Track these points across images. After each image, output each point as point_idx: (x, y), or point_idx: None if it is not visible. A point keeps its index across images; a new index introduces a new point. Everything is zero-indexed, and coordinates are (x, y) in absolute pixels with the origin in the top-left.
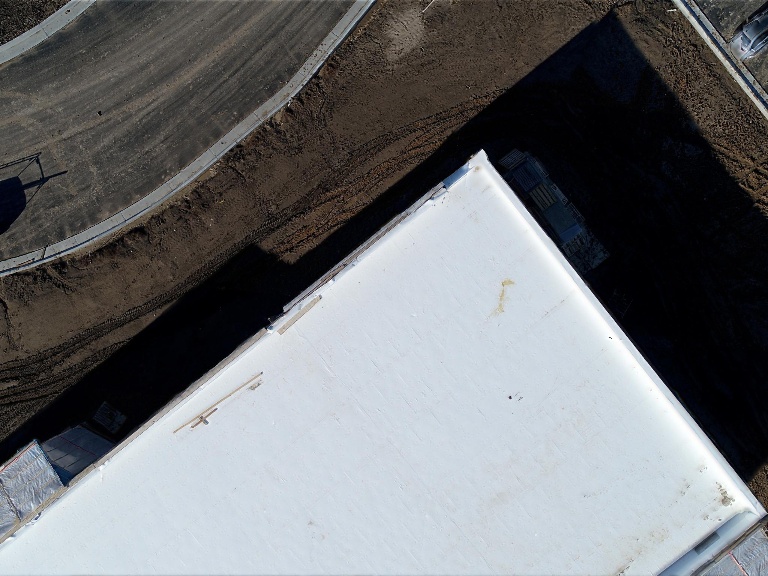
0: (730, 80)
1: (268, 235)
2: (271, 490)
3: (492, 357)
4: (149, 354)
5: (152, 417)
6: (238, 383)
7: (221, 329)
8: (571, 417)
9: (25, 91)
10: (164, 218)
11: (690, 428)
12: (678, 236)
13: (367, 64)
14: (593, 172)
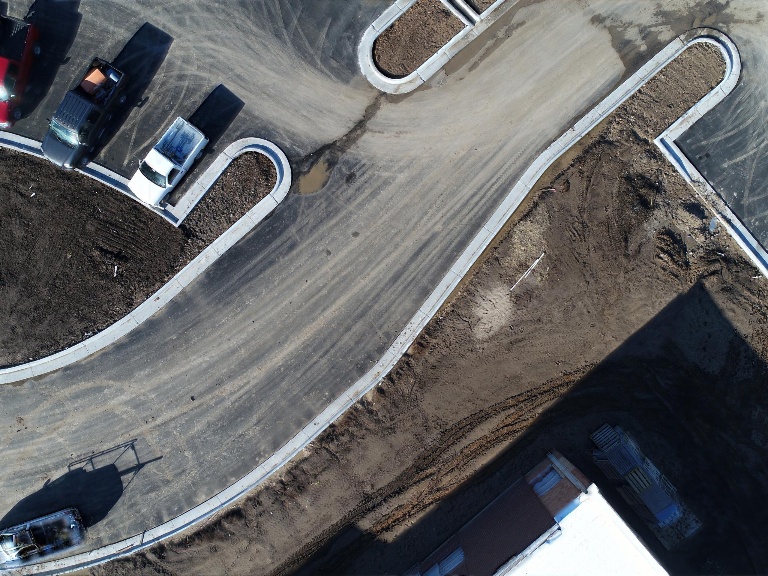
0: None
1: (364, 515)
2: None
3: None
4: None
5: None
6: None
7: None
8: None
9: (118, 379)
10: (260, 500)
11: None
12: None
13: (457, 343)
14: (684, 443)
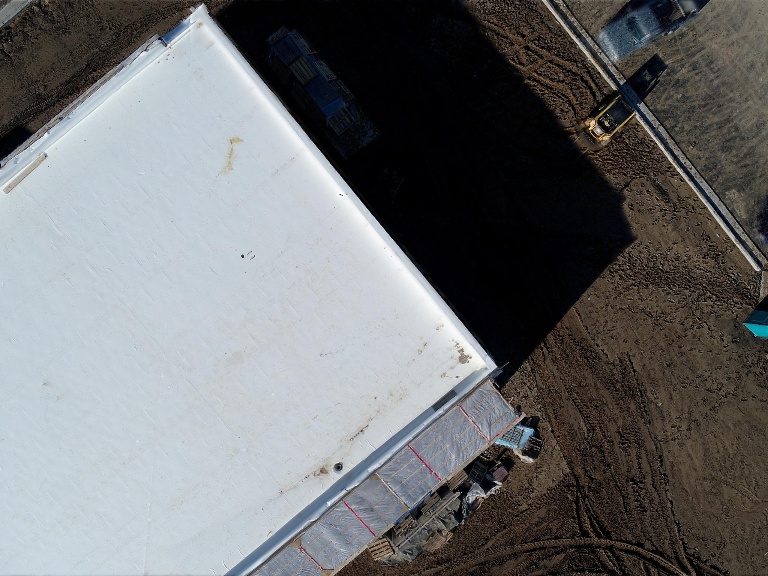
0: None
1: (36, 116)
2: (3, 351)
3: (223, 215)
4: None
5: None
6: None
7: None
8: (305, 275)
9: None
10: None
11: (418, 282)
12: (448, 113)
13: None
14: (362, 50)
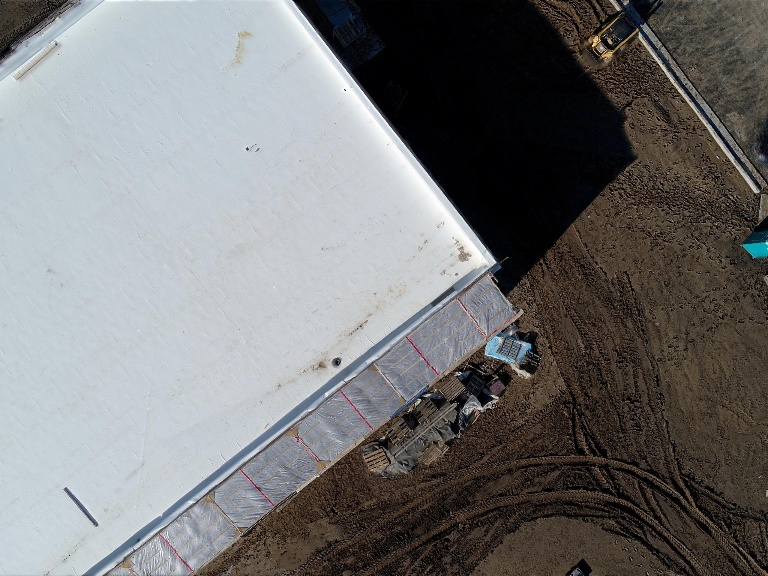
0: None
1: None
2: (9, 236)
3: (229, 108)
4: None
5: None
6: None
7: None
8: (308, 169)
9: None
10: None
11: (420, 177)
12: (453, 29)
13: None
14: None
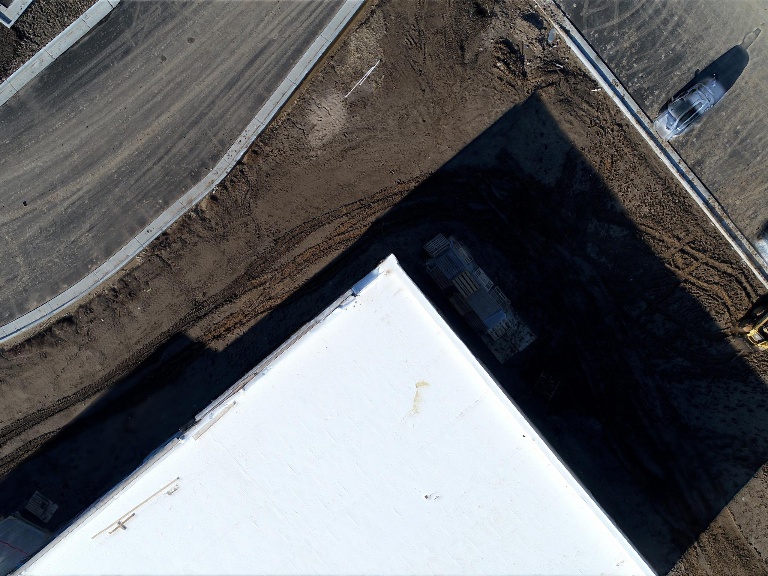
0: (656, 159)
1: (195, 323)
2: None
3: (407, 457)
4: (79, 443)
5: (67, 528)
6: (155, 488)
7: (150, 417)
8: (487, 515)
9: None
10: (92, 307)
11: (604, 526)
12: (604, 317)
13: (291, 150)
14: (519, 255)
